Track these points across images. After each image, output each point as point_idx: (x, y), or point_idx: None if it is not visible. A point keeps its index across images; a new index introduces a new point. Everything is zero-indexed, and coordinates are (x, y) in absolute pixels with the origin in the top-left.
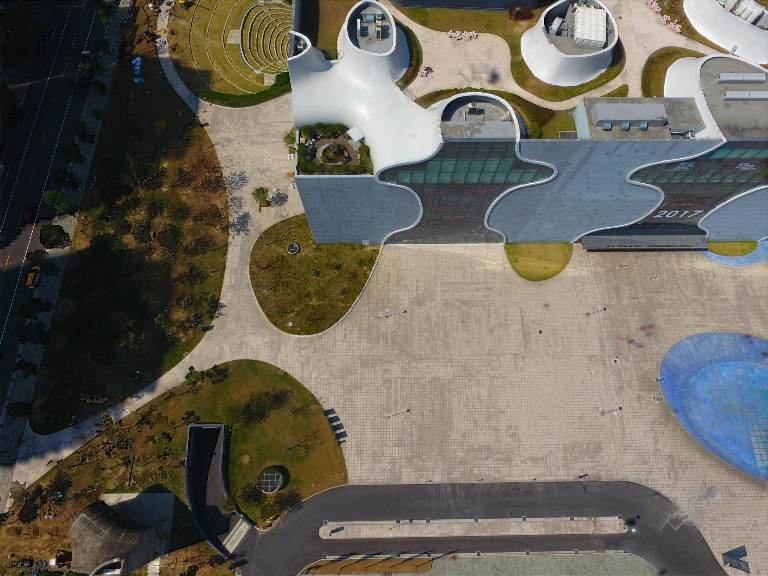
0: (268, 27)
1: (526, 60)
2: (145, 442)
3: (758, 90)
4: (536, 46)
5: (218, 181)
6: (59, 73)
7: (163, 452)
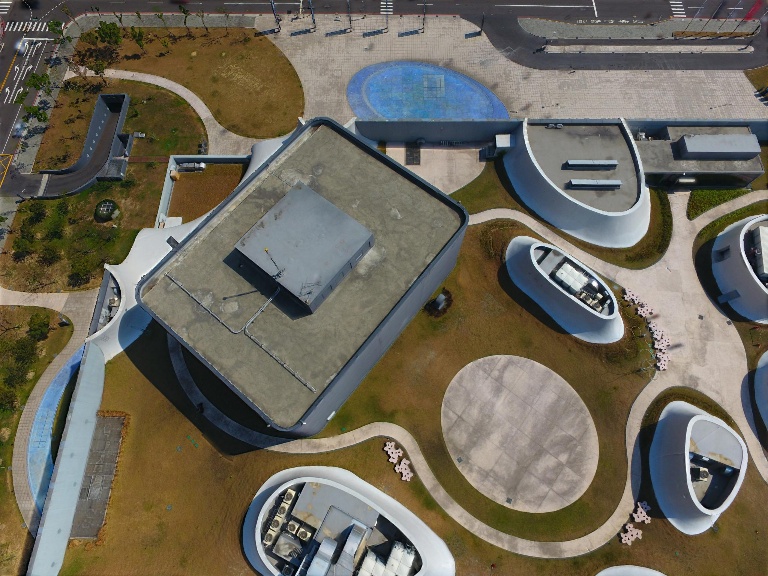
0: None
1: None
2: None
3: (574, 175)
4: None
5: None
6: None
7: None
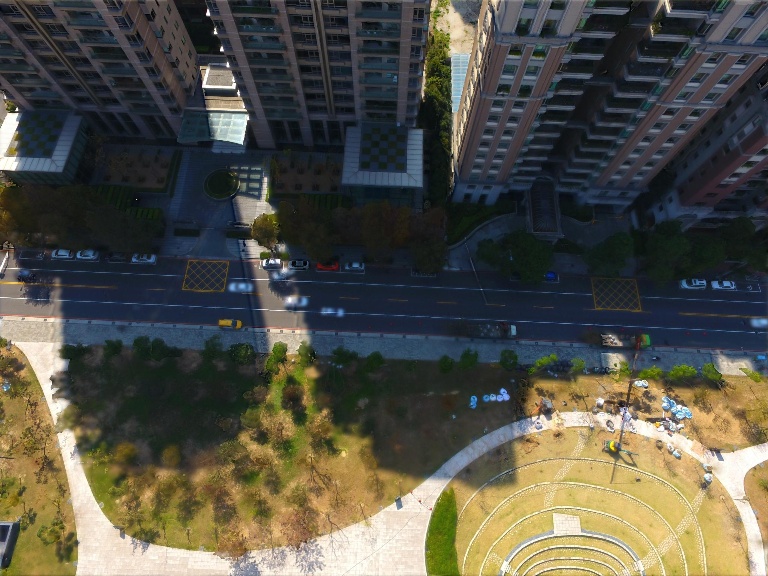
0: (598, 575)
1: None
2: (3, 481)
3: None
4: None
5: (311, 531)
6: (490, 300)
7: (6, 490)
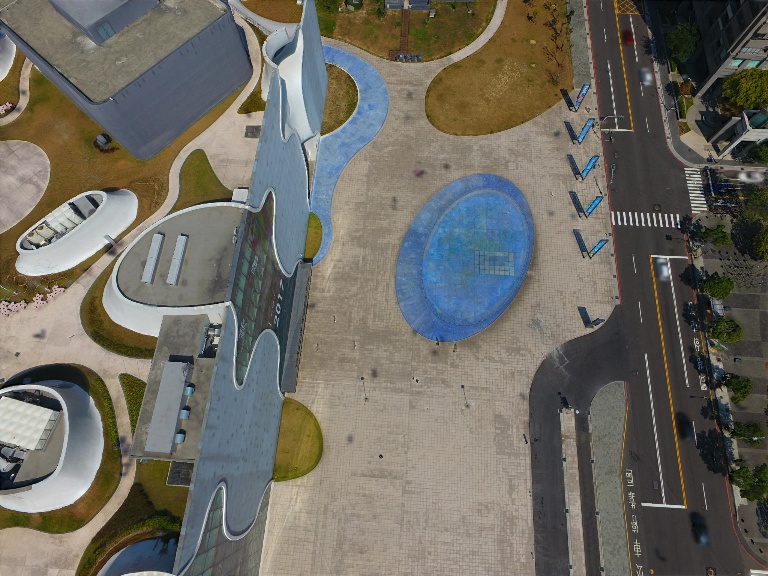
0: None
1: (43, 510)
2: None
3: (172, 244)
4: (25, 499)
5: None
6: None
7: None
